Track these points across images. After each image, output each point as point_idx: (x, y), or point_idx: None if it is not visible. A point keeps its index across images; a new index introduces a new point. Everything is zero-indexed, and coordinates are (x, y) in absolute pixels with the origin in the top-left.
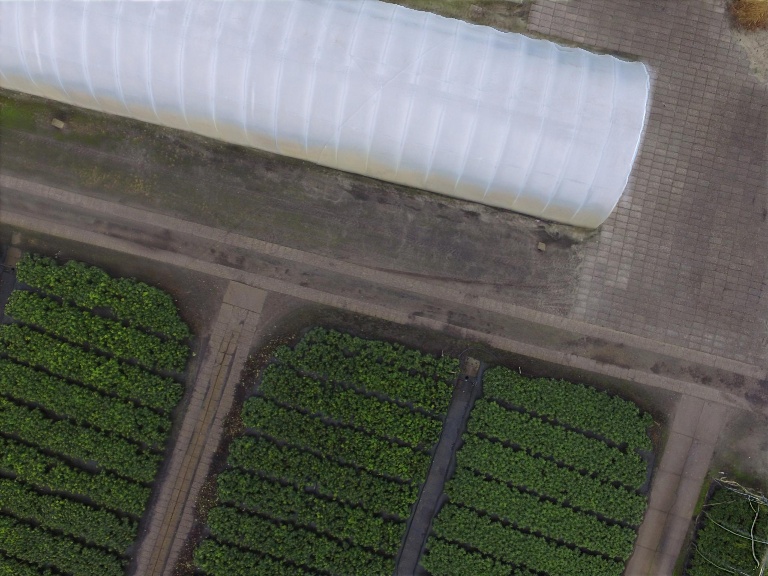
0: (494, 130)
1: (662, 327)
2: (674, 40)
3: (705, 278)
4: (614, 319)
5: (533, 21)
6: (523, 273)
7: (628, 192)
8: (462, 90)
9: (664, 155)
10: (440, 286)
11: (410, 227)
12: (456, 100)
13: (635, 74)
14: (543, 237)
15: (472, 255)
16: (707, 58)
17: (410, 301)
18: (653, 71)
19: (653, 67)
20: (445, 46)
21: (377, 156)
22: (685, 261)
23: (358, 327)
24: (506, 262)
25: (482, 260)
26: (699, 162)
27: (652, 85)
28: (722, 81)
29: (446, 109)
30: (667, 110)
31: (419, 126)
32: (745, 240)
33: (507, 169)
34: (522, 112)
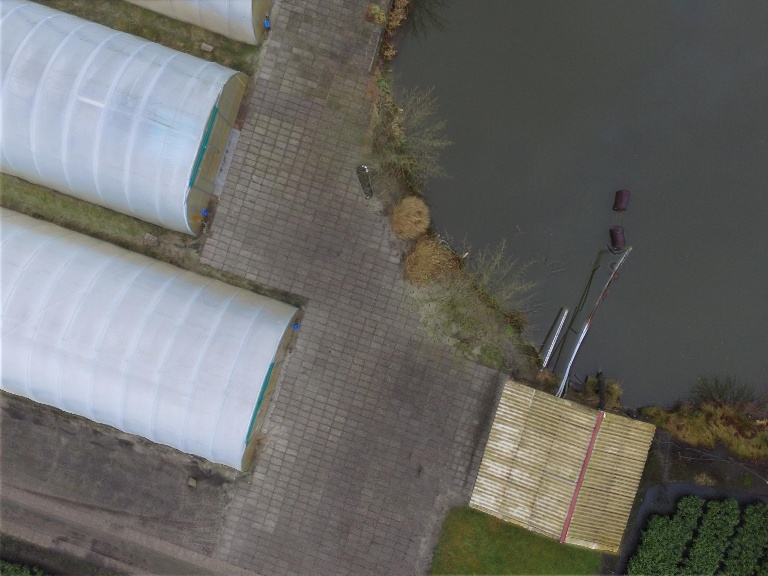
0: (111, 389)
1: (304, 575)
2: (346, 287)
3: (353, 529)
4: (257, 562)
5: (206, 255)
6: (171, 507)
7: (285, 435)
8: (78, 349)
9: (324, 402)
10: (86, 513)
11: (63, 451)
12: (72, 358)
13: (268, 339)
14: (196, 472)
15: (122, 485)
16: (377, 308)
17: (55, 525)
18: (322, 316)
19: (323, 312)
20: (70, 301)
21: (13, 391)
22: (335, 510)
23: (2, 545)
24: (155, 494)
25: (131, 491)
26: (359, 412)
27: (320, 330)
28: (390, 332)
29: (62, 366)
30: (332, 356)
31: (40, 376)
32: (397, 494)
33: (132, 422)
34: (137, 376)
